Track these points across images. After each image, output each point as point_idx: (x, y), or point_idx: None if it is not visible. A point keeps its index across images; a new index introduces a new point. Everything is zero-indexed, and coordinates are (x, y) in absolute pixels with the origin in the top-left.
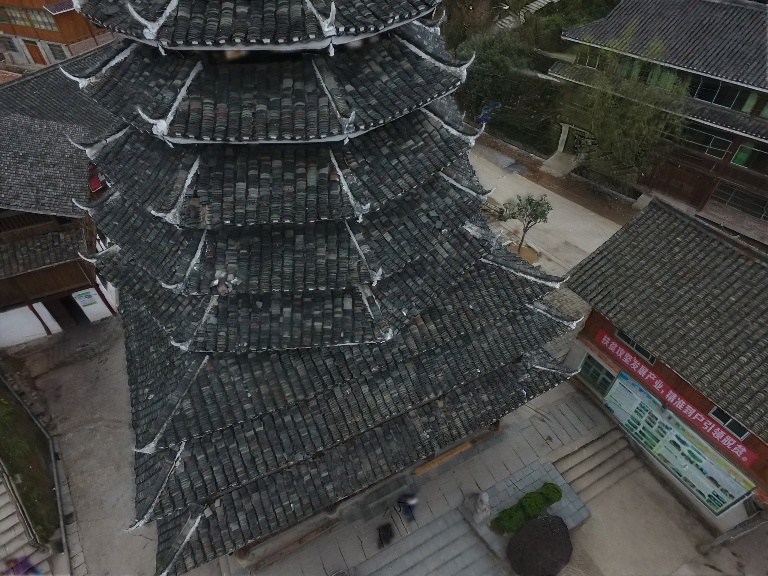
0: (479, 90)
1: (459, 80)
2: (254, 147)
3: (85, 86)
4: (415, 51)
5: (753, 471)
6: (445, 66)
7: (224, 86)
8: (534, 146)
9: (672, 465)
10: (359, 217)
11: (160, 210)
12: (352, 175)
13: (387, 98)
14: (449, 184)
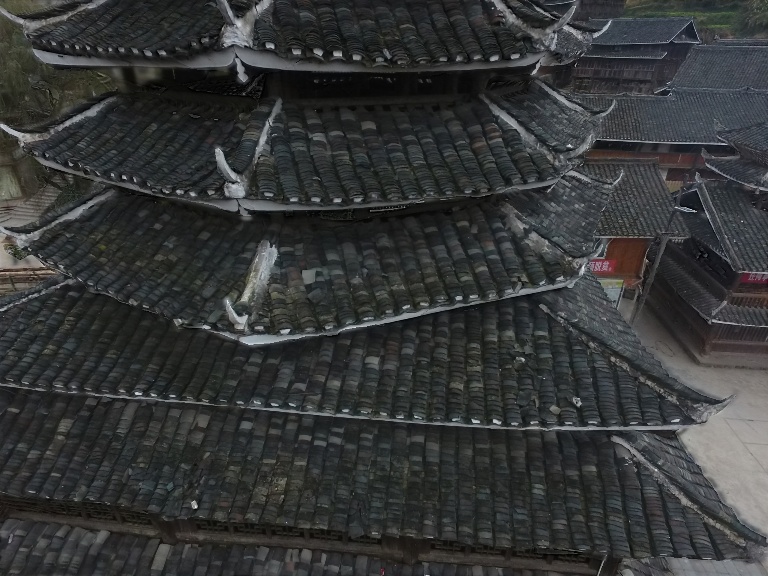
0: None
1: None
2: None
3: None
4: None
5: (617, 272)
6: None
7: None
8: None
9: None
10: None
11: None
12: None
13: None
14: None
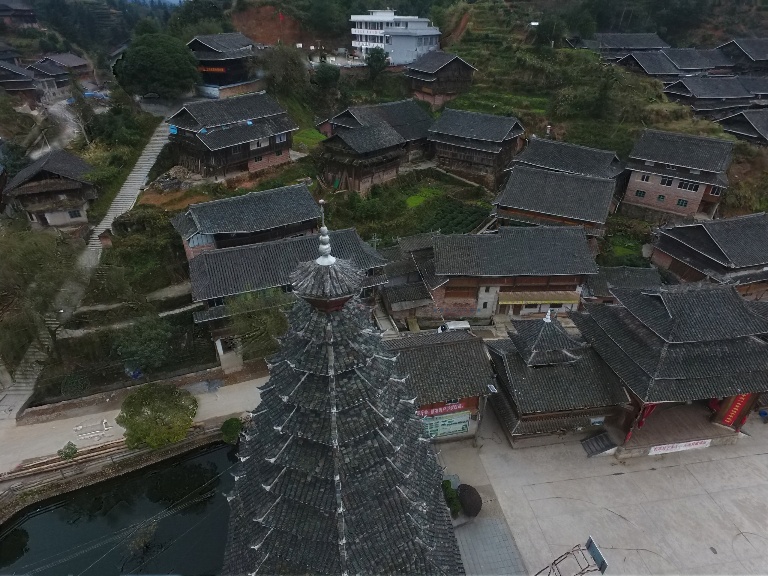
0: (158, 361)
1: None
2: None
3: (342, 509)
4: None
5: (466, 408)
6: None
7: None
8: (197, 364)
9: (446, 432)
10: None
11: (416, 502)
12: None
13: None
14: None
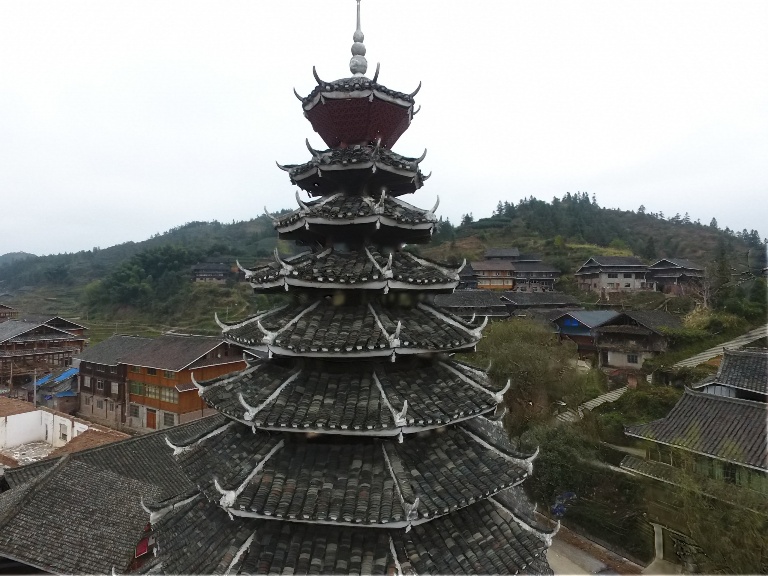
0: (549, 478)
1: (526, 472)
2: (312, 526)
3: (178, 453)
4: (479, 442)
5: None
6: (510, 457)
7: (298, 463)
8: (625, 548)
9: None
10: None
11: None
12: (412, 571)
13: (452, 485)
14: None
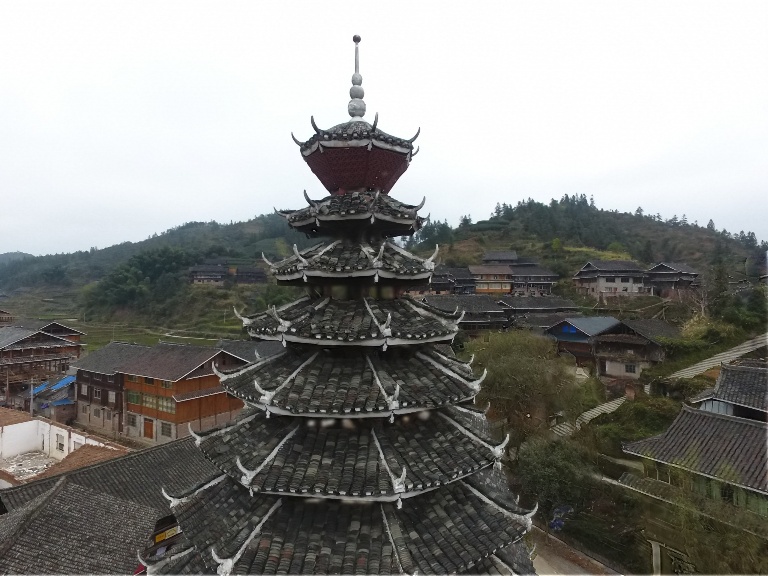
0: (547, 495)
1: (525, 529)
2: None
3: (175, 505)
4: (478, 495)
5: None
6: (509, 513)
7: (296, 524)
8: (623, 564)
9: None
10: None
11: None
12: None
13: (451, 548)
14: None
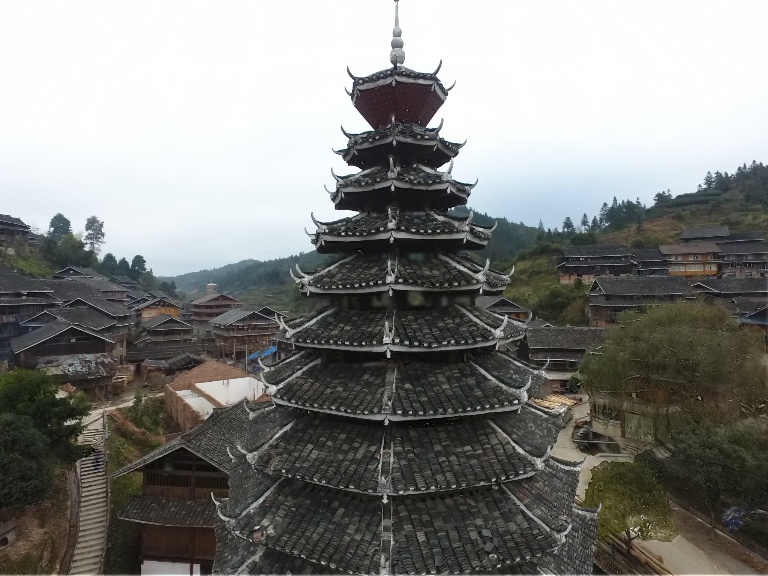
0: (705, 478)
1: (517, 399)
2: (335, 422)
3: (267, 372)
4: (484, 374)
5: None
6: (507, 387)
7: (326, 374)
8: None
9: None
10: (384, 496)
11: (246, 449)
12: (389, 455)
13: (438, 399)
14: (519, 509)
